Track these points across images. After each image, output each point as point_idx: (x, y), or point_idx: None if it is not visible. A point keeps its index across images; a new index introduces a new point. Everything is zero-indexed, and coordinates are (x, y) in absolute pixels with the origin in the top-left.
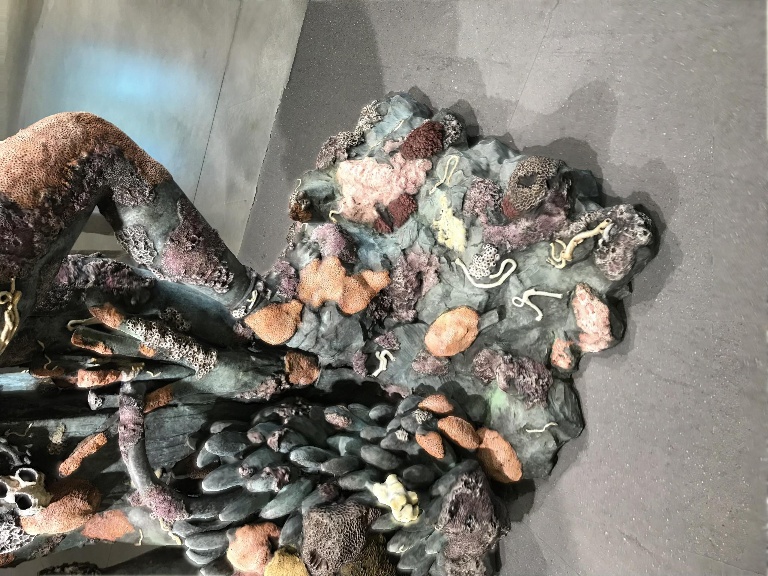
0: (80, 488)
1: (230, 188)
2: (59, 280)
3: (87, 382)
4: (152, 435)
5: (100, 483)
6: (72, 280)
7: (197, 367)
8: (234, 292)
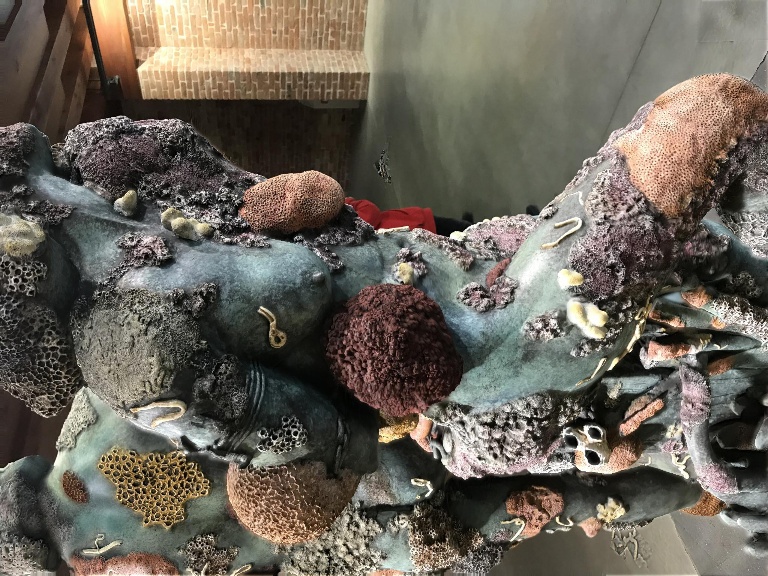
0: (628, 440)
1: (709, 23)
2: None
3: (661, 358)
4: None
5: (641, 433)
6: None
7: (766, 340)
8: None
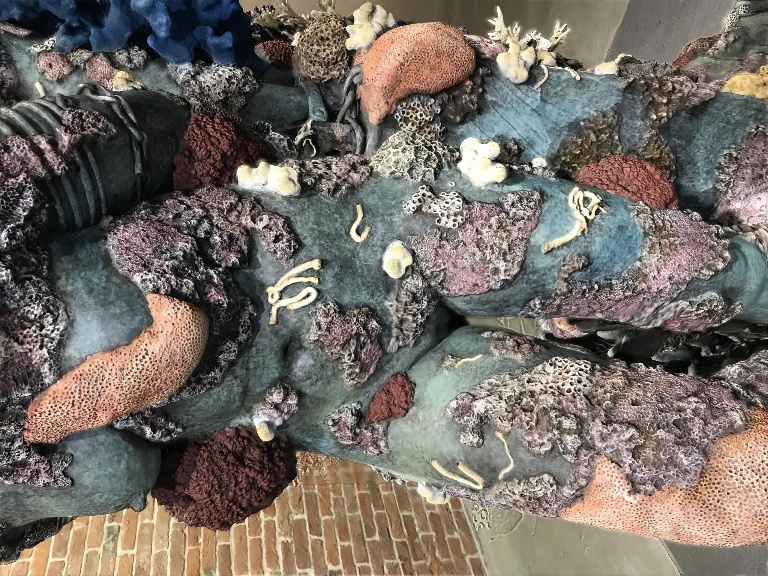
0: None
1: None
2: (619, 315)
3: None
4: None
5: None
6: (632, 321)
7: None
8: None
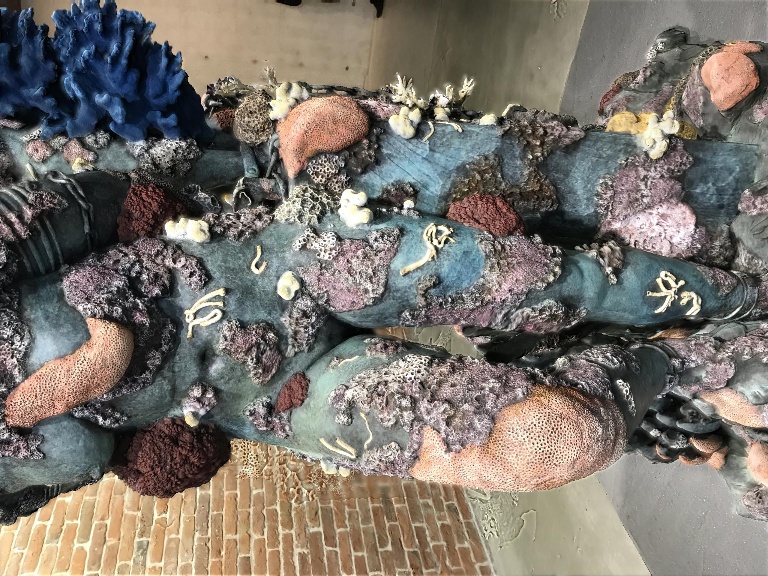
0: None
1: None
2: (480, 322)
3: None
4: None
5: None
6: (491, 326)
7: None
8: None
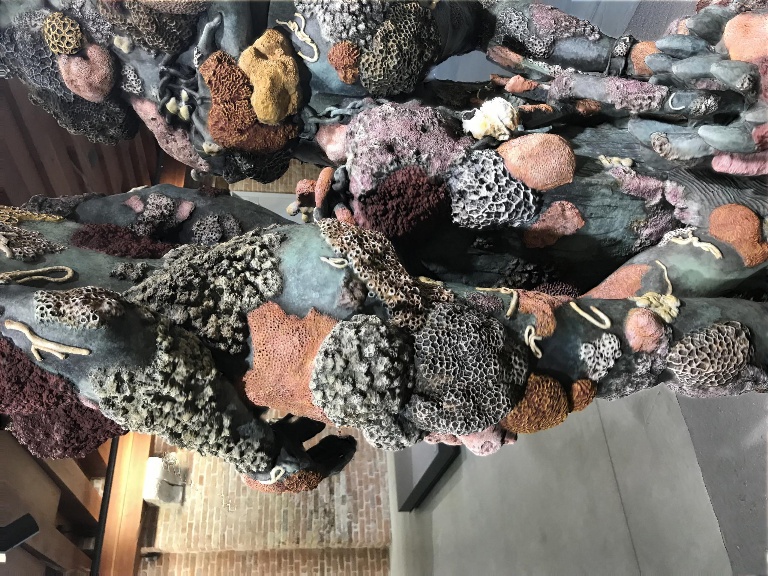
0: None
1: (640, 408)
2: None
3: None
4: (601, 140)
5: None
6: None
7: None
8: (607, 41)
